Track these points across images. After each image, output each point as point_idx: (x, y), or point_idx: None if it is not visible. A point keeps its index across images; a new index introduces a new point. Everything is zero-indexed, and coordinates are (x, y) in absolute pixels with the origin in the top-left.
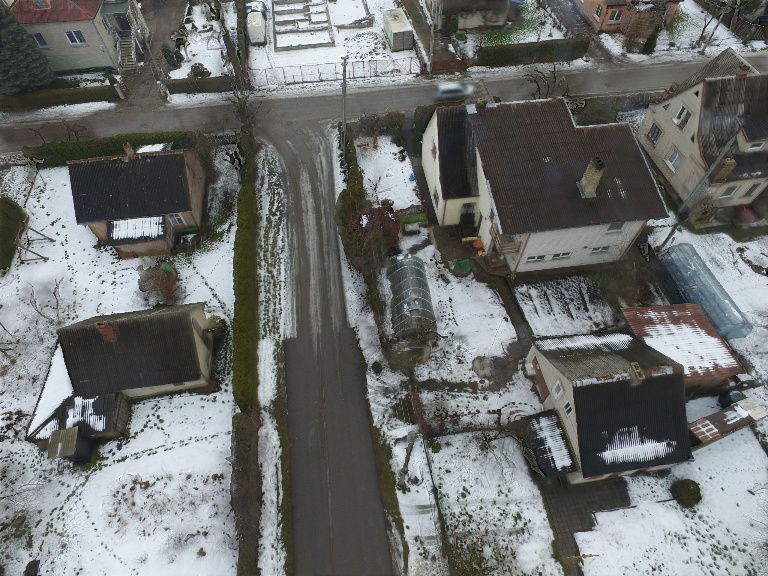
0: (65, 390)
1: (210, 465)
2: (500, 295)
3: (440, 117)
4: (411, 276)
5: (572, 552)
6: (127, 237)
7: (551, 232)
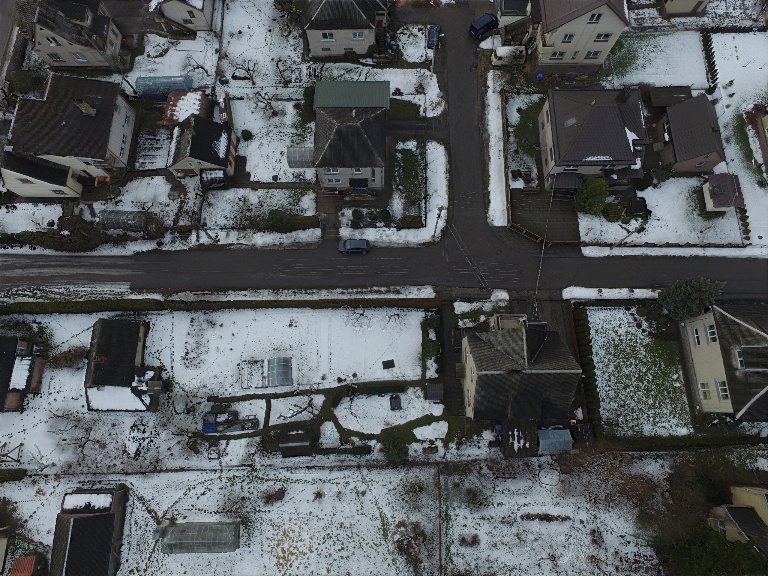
0: (126, 393)
1: (186, 325)
2: (137, 177)
3: (7, 168)
4: (112, 216)
5: (256, 184)
6: (26, 380)
7: (109, 138)
